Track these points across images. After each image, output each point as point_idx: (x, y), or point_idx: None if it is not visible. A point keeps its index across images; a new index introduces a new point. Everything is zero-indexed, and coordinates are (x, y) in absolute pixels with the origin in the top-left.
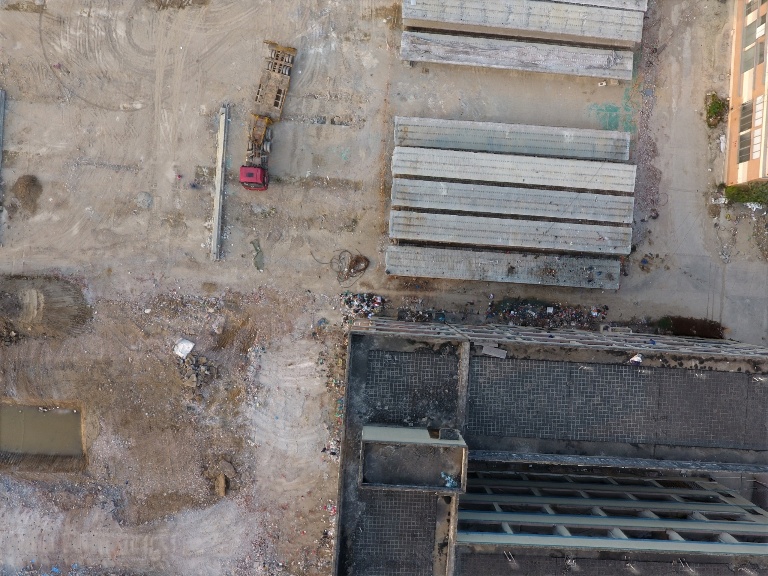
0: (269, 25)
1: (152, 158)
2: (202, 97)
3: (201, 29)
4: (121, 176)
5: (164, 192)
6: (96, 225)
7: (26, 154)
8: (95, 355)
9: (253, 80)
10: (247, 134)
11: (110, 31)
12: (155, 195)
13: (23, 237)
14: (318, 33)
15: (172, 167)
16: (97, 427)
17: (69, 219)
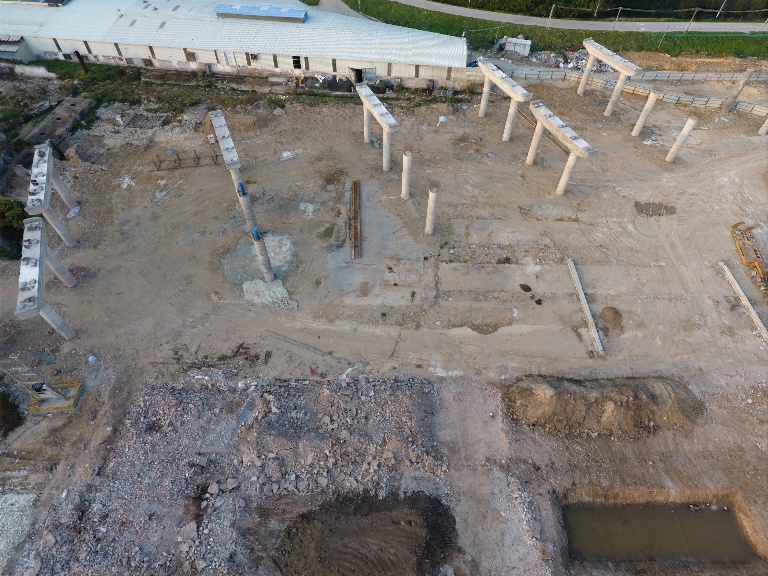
0: (719, 221)
1: (690, 293)
2: (702, 257)
3: (679, 225)
4: (675, 304)
5: (711, 313)
6: (672, 337)
7: (601, 294)
8: (726, 443)
9: (729, 247)
10: (749, 275)
11: (624, 228)
12: (706, 315)
13: (622, 348)
14: (752, 223)
15: (707, 297)
16: (767, 518)
17: (650, 334)
